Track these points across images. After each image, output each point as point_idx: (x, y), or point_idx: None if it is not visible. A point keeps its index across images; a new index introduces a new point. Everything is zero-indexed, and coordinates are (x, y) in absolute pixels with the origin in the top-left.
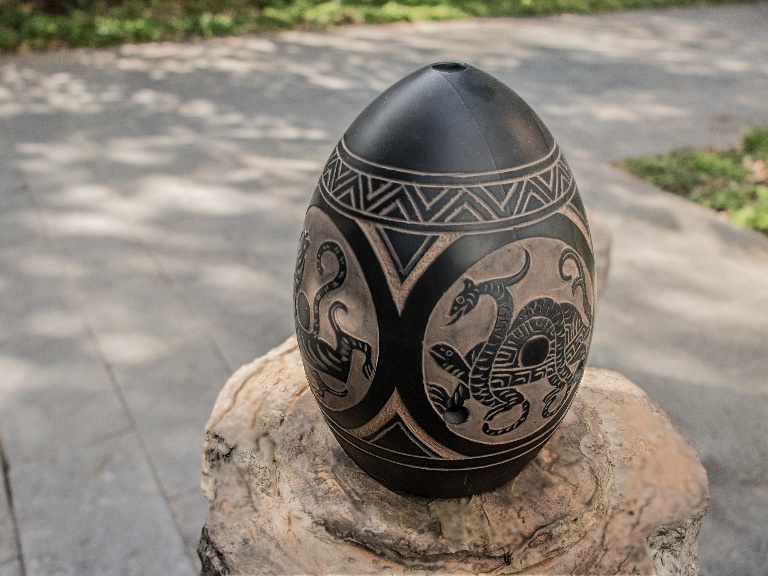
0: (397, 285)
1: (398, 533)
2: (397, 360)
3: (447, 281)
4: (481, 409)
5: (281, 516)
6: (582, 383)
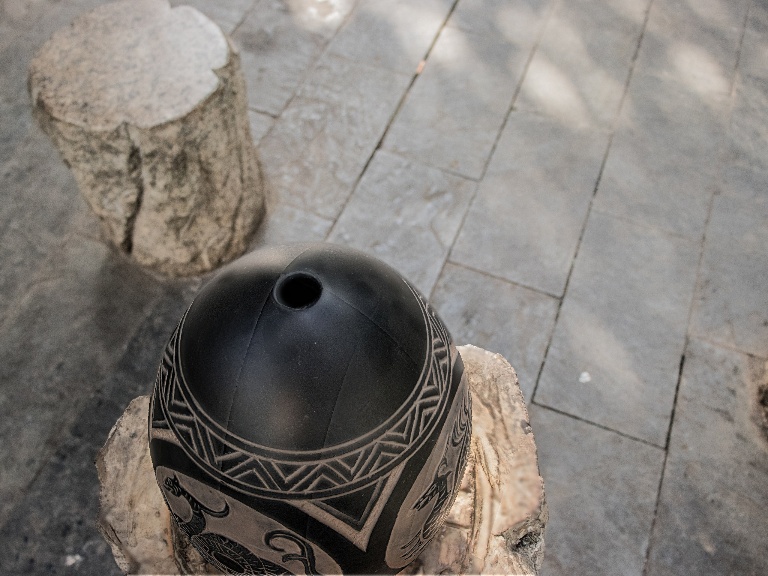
0: None
1: None
2: None
3: None
4: None
5: None
6: (486, 574)
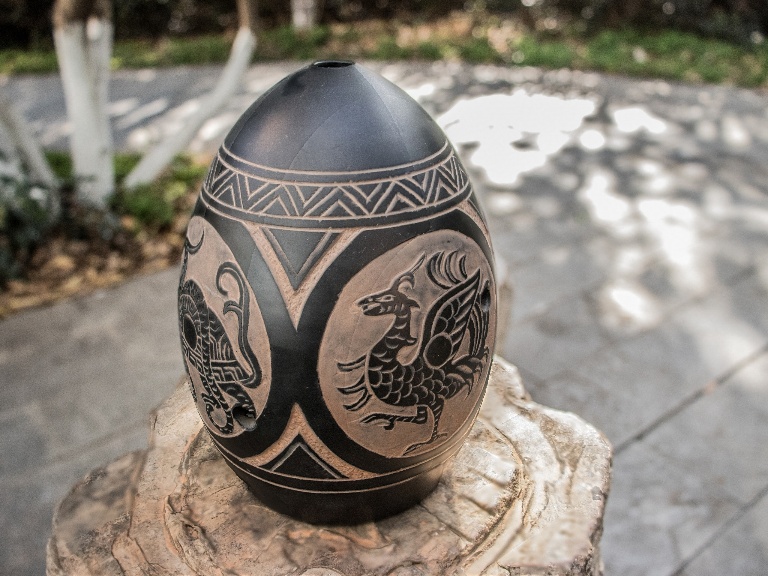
0: None
1: None
2: None
3: None
4: None
5: None
6: None
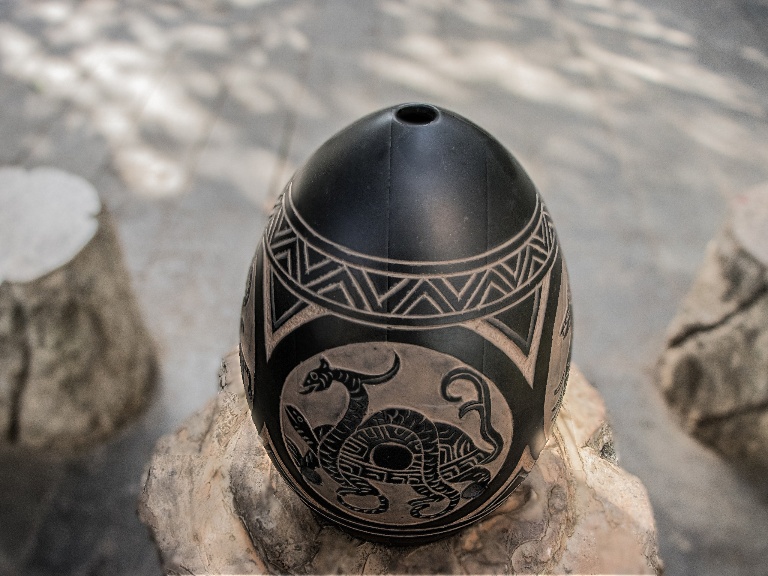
0: (270, 333)
1: (280, 538)
2: (264, 400)
3: (306, 352)
4: (332, 482)
5: (213, 466)
6: (591, 481)
